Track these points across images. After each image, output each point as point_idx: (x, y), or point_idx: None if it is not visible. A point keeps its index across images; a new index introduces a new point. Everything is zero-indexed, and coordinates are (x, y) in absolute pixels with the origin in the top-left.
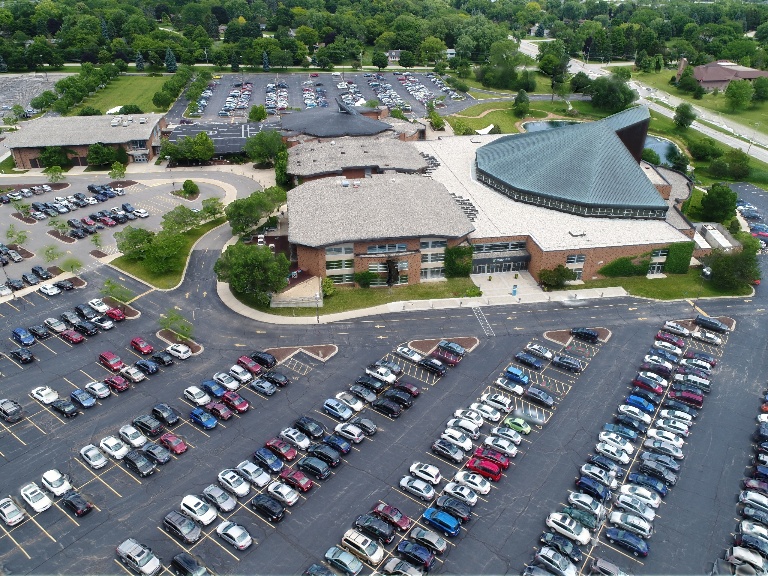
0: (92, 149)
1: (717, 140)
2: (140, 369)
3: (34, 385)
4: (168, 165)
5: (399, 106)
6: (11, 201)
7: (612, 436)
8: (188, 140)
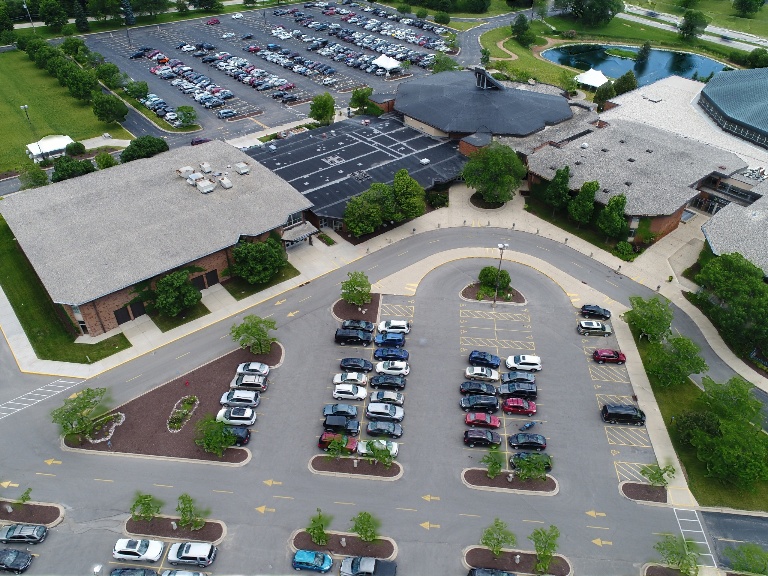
0: (254, 256)
1: (731, 47)
2: None
3: None
4: (349, 239)
5: (421, 57)
6: (331, 447)
7: None
8: (385, 190)
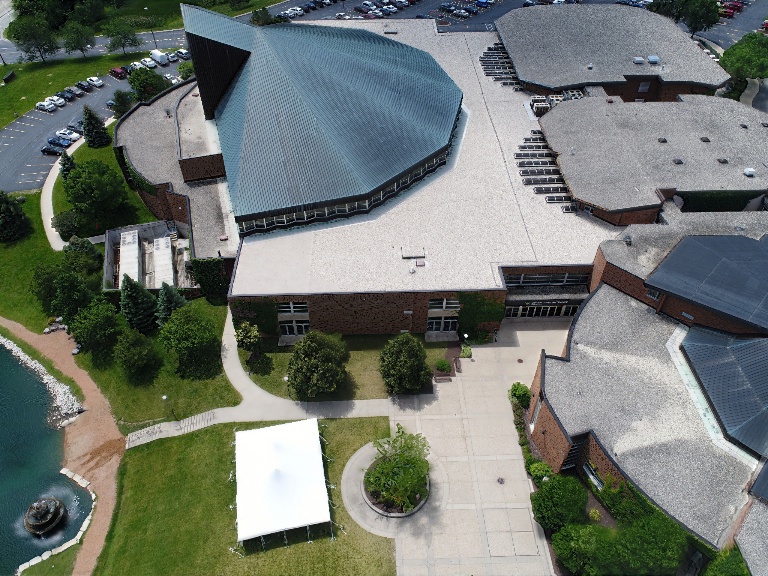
0: None
1: None
2: None
3: (762, 0)
4: None
5: None
6: None
7: None
8: None
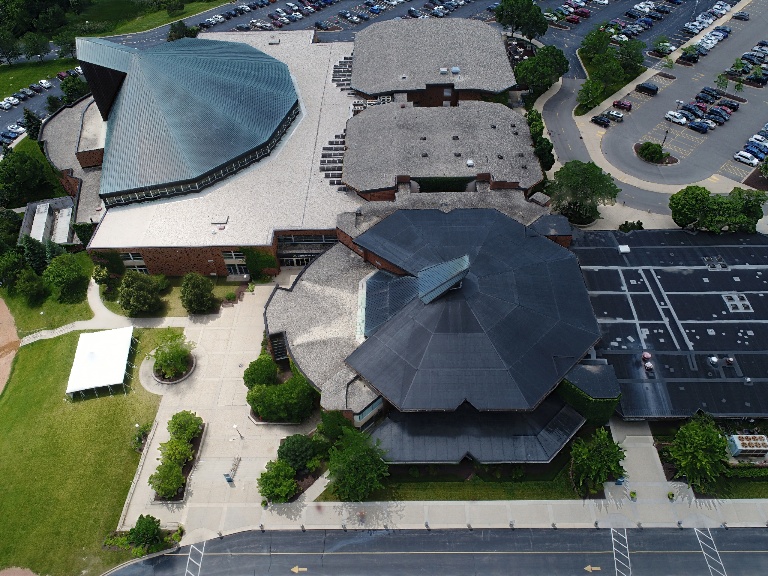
0: None
1: None
2: (563, 7)
3: (612, 6)
4: None
5: None
6: None
7: None
8: (721, 198)
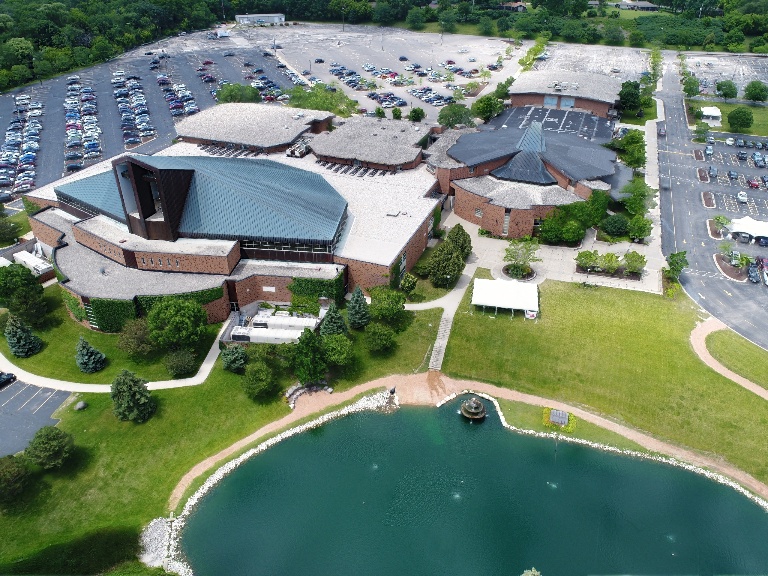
0: None
1: None
2: None
3: None
4: None
5: None
6: None
7: (32, 144)
8: None
